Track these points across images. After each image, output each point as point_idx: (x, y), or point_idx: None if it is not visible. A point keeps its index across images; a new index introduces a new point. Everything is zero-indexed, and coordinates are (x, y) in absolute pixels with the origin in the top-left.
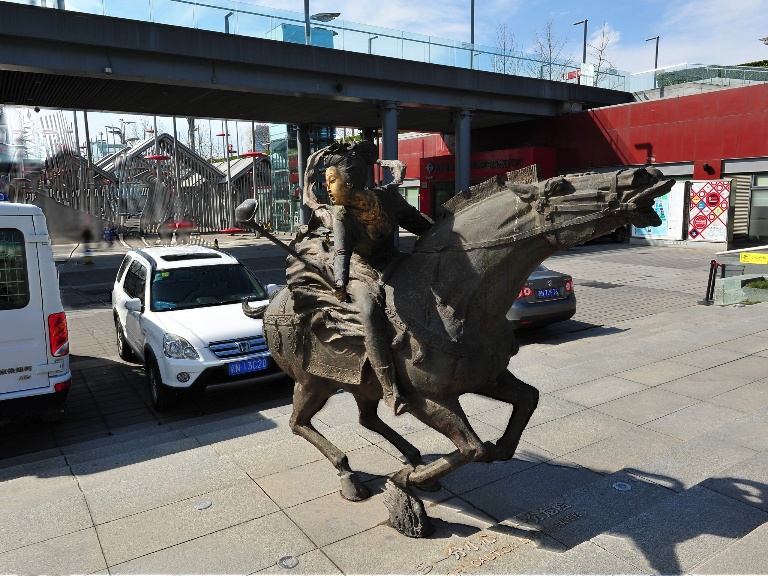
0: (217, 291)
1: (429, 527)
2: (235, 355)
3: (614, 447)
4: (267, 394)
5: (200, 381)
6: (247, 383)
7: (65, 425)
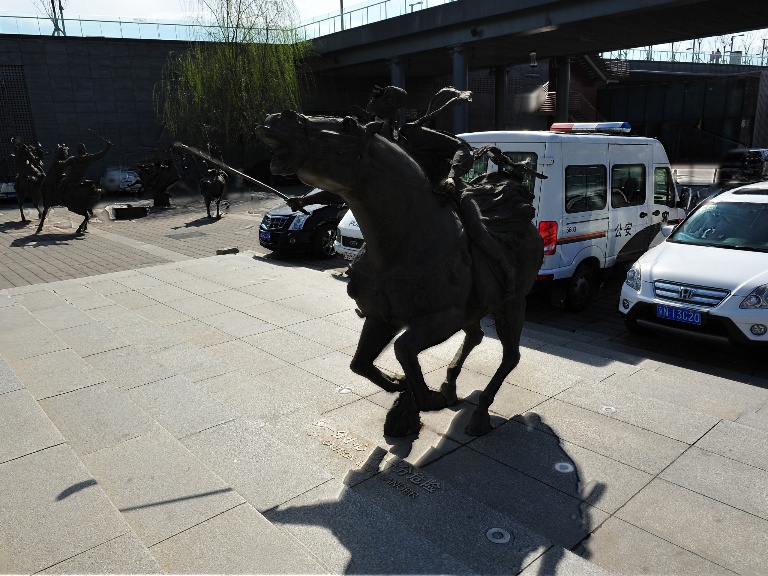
0: (765, 235)
1: (393, 430)
2: (673, 299)
3: (695, 574)
4: (738, 363)
5: (632, 312)
6: (678, 332)
7: (571, 315)
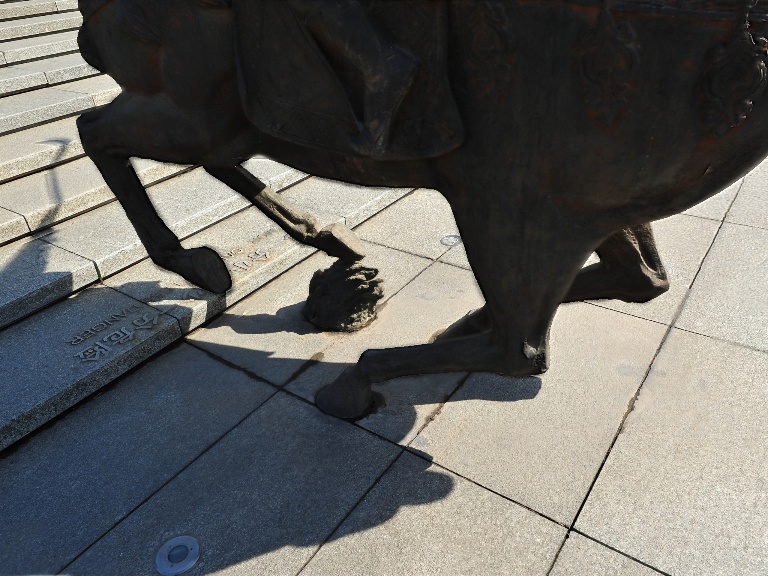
0: None
1: None
2: None
3: None
4: None
5: None
6: None
7: None
